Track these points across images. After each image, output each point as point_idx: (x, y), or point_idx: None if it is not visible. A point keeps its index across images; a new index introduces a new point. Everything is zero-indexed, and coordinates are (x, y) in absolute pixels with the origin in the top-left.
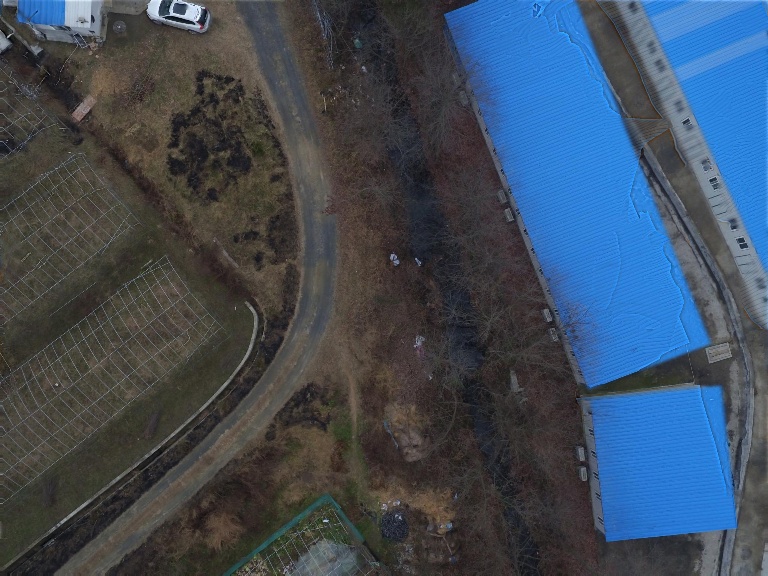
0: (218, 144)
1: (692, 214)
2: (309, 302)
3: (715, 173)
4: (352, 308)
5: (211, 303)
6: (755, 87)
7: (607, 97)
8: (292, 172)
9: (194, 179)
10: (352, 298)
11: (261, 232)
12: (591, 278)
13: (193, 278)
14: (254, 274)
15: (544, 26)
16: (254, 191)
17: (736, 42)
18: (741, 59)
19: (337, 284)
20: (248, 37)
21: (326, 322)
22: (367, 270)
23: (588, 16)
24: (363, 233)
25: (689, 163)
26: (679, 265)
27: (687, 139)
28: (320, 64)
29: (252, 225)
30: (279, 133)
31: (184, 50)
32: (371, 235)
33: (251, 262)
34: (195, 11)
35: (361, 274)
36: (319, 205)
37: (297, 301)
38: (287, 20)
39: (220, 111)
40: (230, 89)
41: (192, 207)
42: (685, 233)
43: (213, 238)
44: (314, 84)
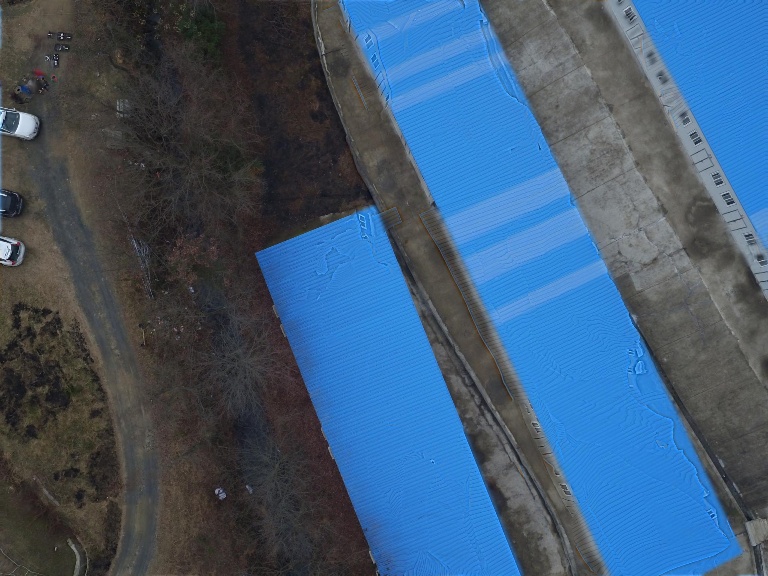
0: (36, 379)
1: (523, 447)
2: (131, 541)
3: (536, 419)
4: (175, 546)
5: (24, 553)
6: (579, 325)
7: (432, 328)
8: (112, 407)
9: (12, 416)
10: (175, 536)
11: (81, 469)
12: (424, 507)
13: (6, 526)
14: (75, 512)
15: (367, 254)
16: (74, 427)
17: (559, 278)
18: (564, 297)
19: (159, 522)
20: (65, 267)
21: (148, 561)
22: (190, 507)
23: (415, 239)
24: (185, 469)
25: (515, 399)
26: (512, 497)
27: (512, 376)
28: (139, 295)
29: (72, 462)
30: (98, 367)
31: (0, 282)
32: (194, 471)
33: (72, 500)
34: (5, 249)
35: (184, 511)
36: (140, 440)
37: (119, 540)
38: (105, 249)
39: (37, 346)
40: (47, 322)
41: (11, 444)
42: (518, 463)
43: (33, 476)
44: (133, 316)
